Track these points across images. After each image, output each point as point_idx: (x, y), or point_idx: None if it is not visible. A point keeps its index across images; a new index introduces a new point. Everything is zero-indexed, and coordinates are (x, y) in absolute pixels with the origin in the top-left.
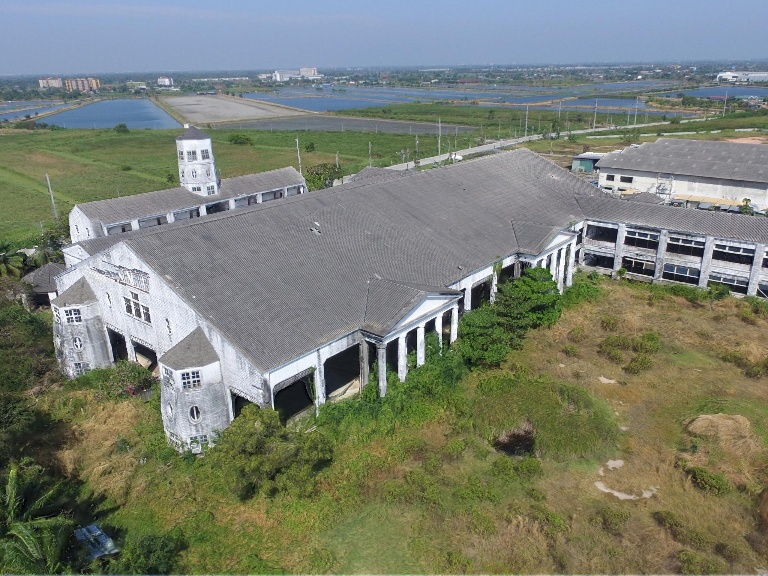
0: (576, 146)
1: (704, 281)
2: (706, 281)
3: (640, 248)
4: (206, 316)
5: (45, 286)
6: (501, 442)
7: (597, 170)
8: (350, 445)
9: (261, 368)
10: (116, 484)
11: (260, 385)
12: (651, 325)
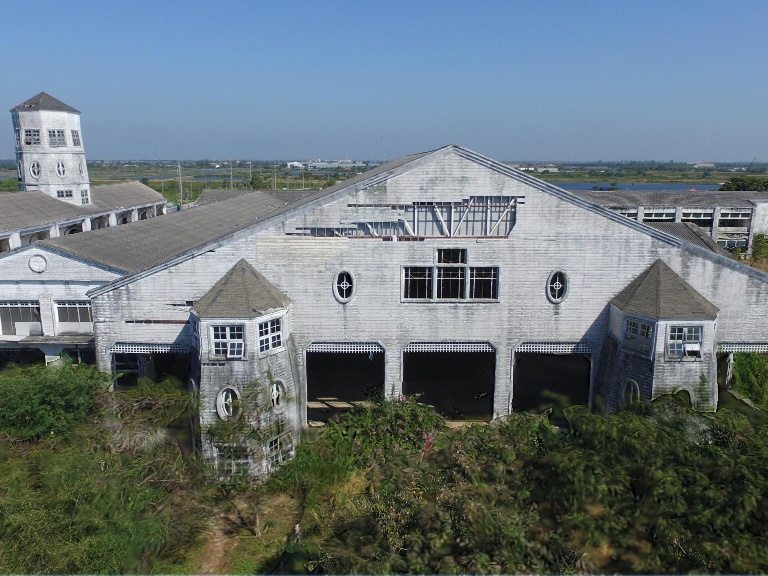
0: None
1: None
2: None
3: None
4: None
5: None
6: None
7: None
8: (762, 405)
9: None
10: None
11: None
12: None
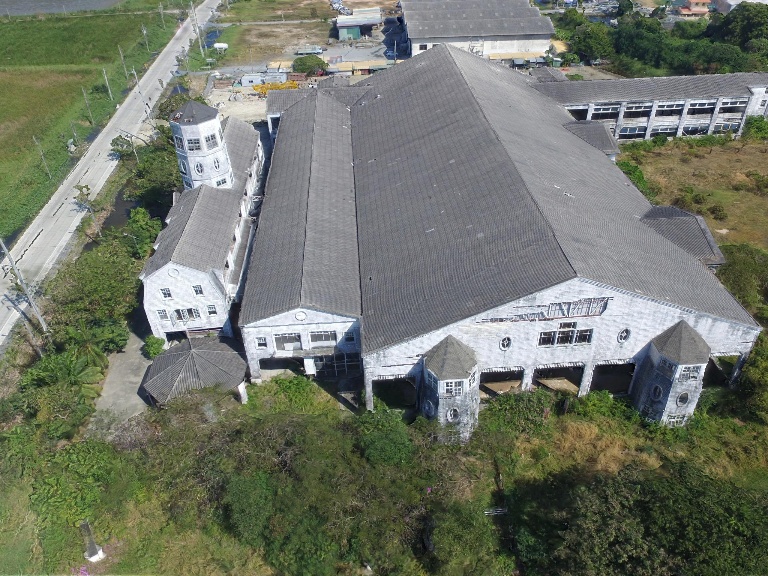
0: (283, 6)
1: (649, 134)
2: (650, 134)
3: (603, 120)
4: (695, 309)
5: (227, 380)
6: (763, 300)
7: (366, 36)
8: None
9: (759, 326)
10: (715, 473)
11: (753, 339)
12: (668, 180)
